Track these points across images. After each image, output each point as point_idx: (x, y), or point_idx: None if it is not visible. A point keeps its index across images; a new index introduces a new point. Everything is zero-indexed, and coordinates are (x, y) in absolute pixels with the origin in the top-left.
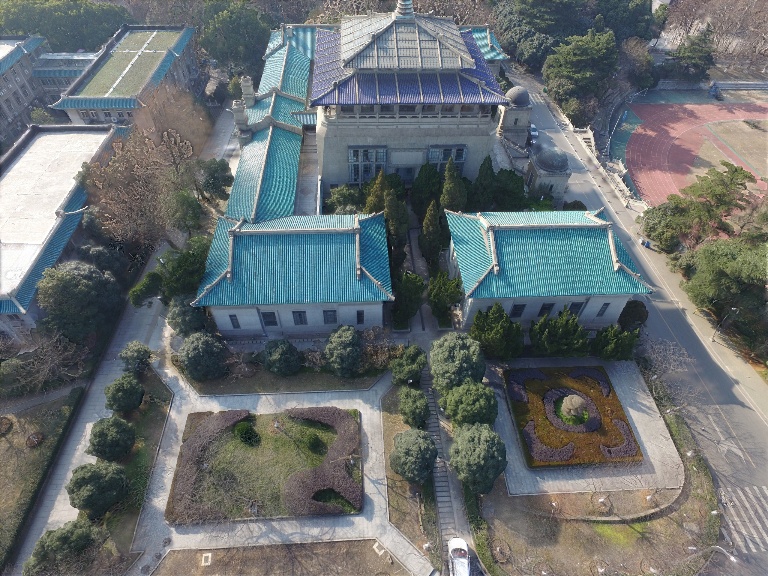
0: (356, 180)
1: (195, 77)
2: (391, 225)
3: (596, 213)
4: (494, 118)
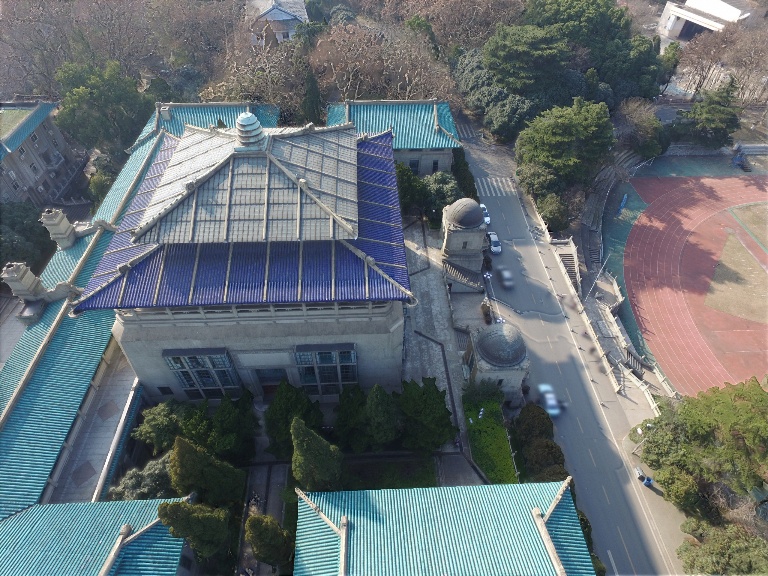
0: (192, 385)
1: (54, 168)
2: (188, 541)
3: (553, 506)
4: (439, 232)
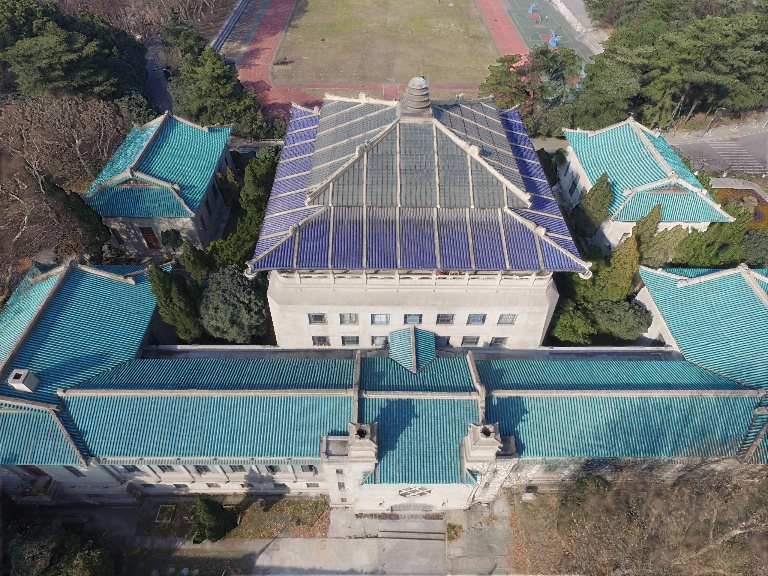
0: None
1: None
2: None
3: None
4: None
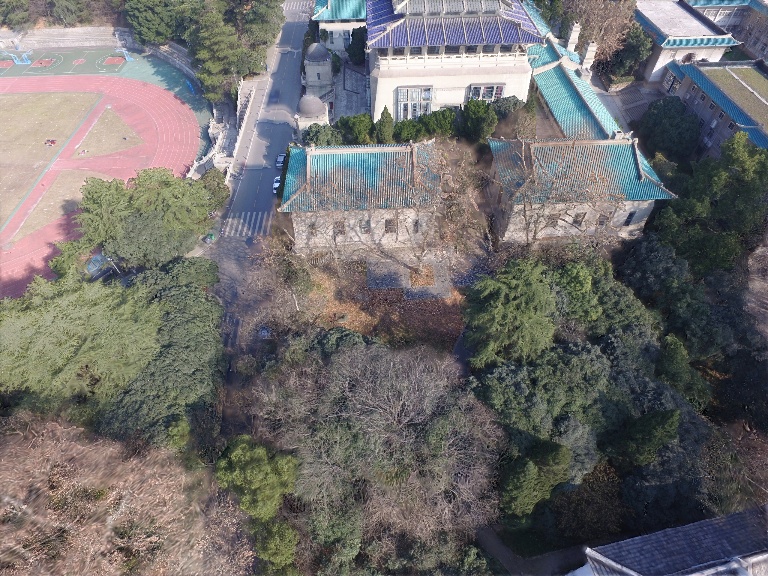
0: None
1: None
2: None
3: (322, 9)
4: None
